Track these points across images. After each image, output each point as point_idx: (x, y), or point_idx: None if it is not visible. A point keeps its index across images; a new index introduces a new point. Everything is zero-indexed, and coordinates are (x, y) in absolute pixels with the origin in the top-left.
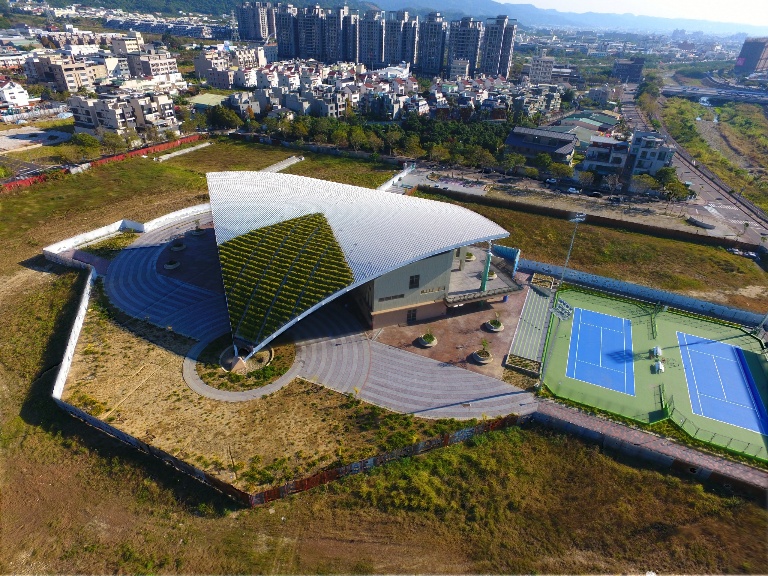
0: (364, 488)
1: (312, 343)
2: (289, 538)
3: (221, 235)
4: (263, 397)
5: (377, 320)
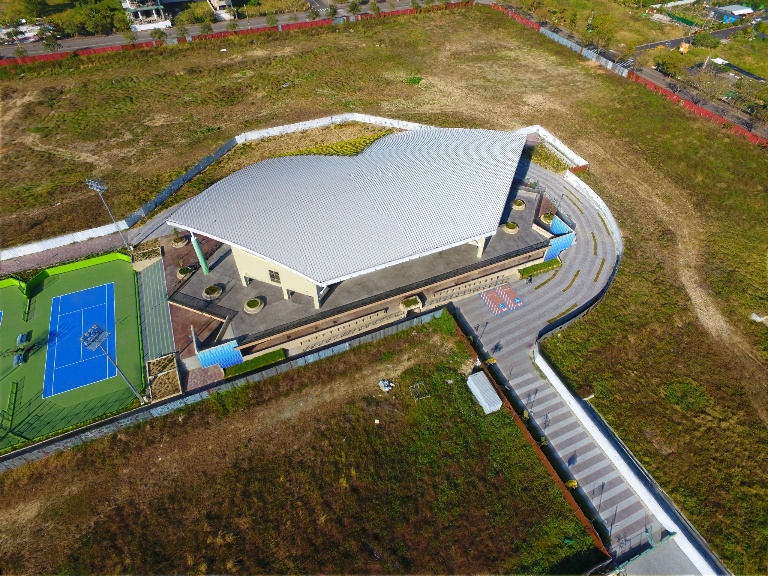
0: (197, 162)
1: None
2: None
3: None
4: None
5: None
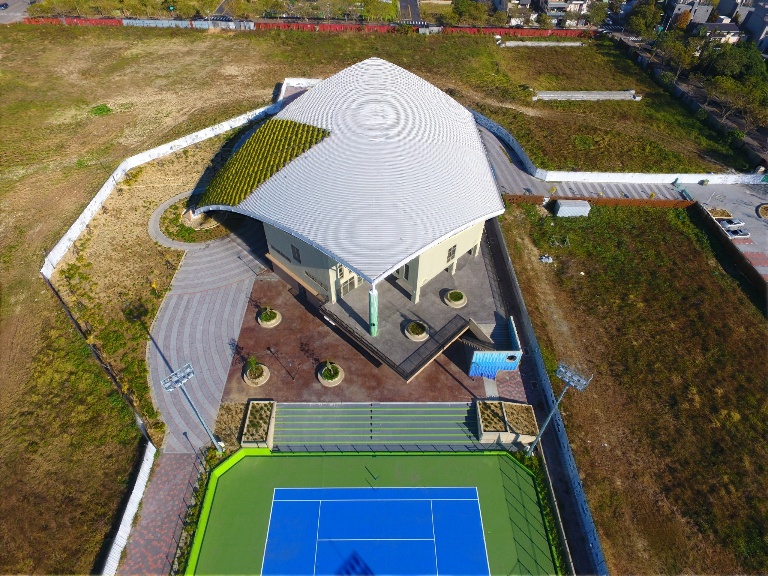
0: (54, 331)
1: (236, 242)
2: (20, 309)
3: (281, 113)
4: (156, 242)
5: (275, 266)
